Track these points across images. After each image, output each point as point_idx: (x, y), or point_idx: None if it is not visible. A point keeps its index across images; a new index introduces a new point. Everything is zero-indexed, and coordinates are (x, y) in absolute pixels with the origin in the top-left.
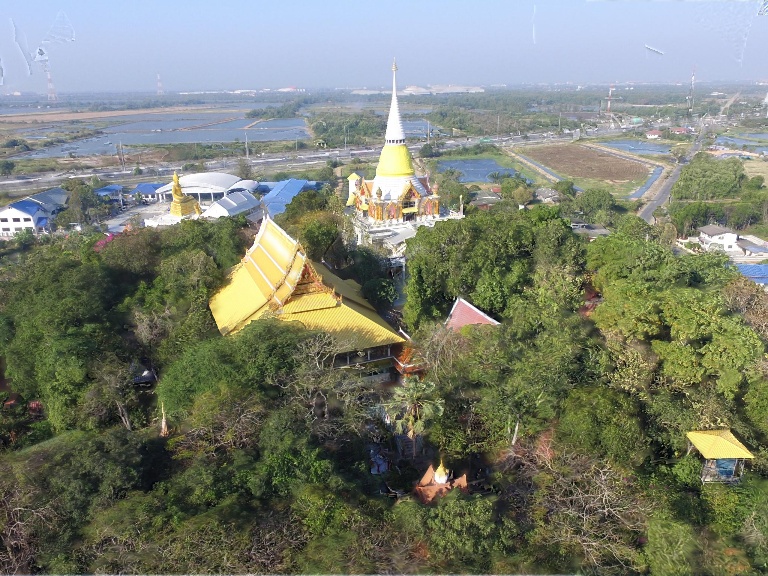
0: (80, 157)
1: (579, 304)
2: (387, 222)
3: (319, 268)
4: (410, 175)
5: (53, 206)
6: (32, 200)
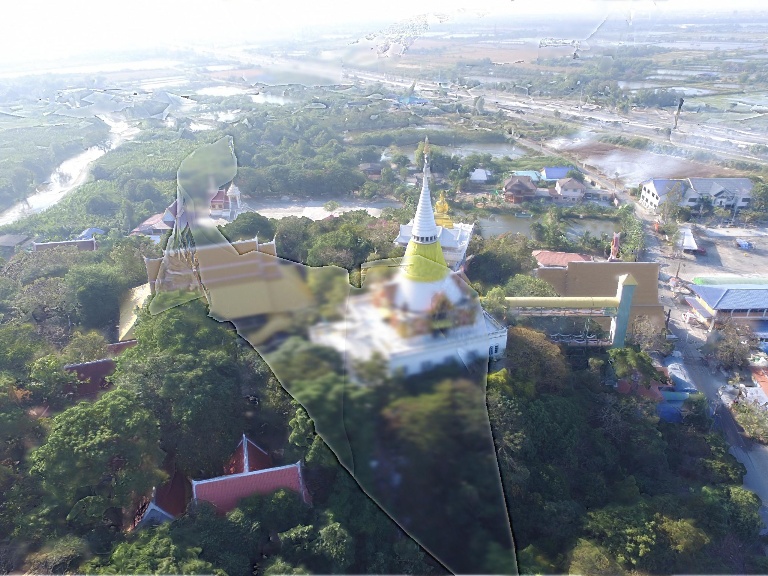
0: None
1: (38, 384)
2: None
3: None
4: None
5: (694, 194)
6: (689, 182)
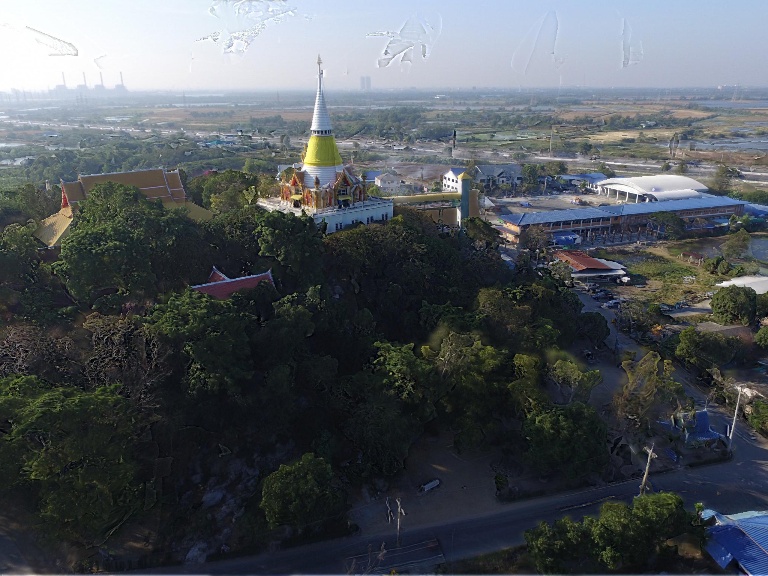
0: (698, 150)
1: None
2: (285, 203)
3: None
4: (314, 165)
5: (483, 176)
6: (478, 169)
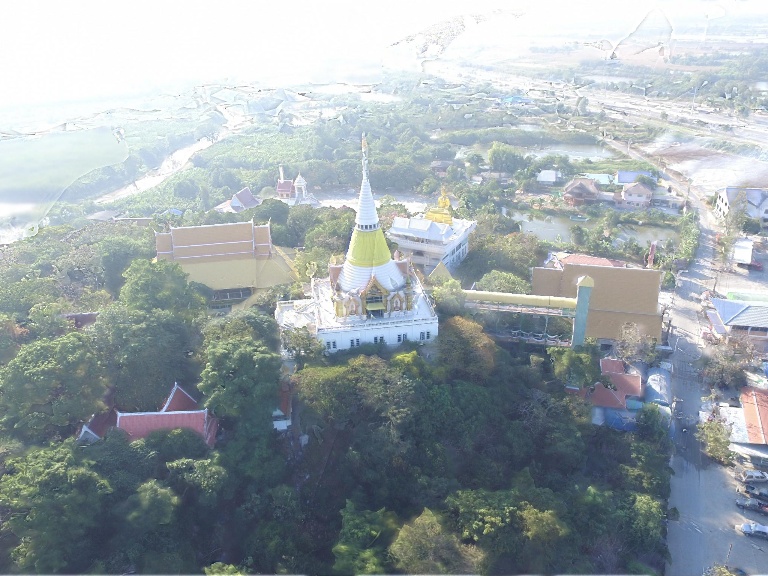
0: None
1: (35, 325)
2: None
3: (251, 271)
4: None
5: None
6: None
